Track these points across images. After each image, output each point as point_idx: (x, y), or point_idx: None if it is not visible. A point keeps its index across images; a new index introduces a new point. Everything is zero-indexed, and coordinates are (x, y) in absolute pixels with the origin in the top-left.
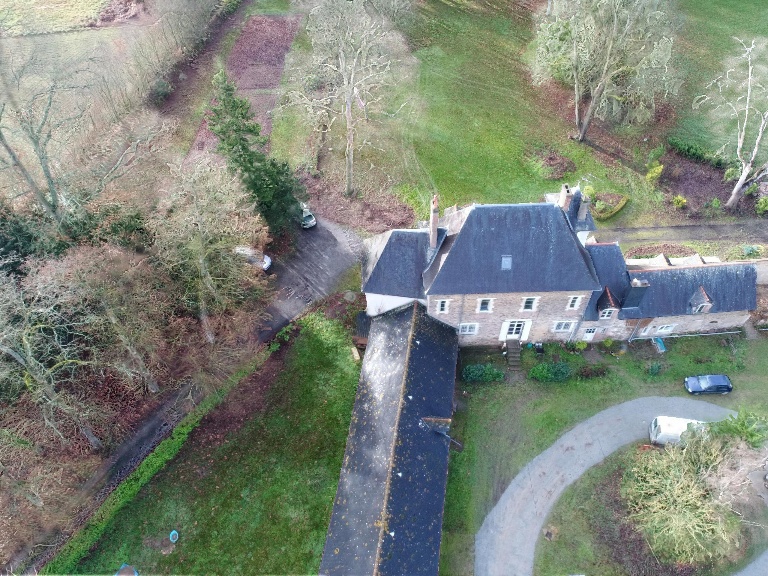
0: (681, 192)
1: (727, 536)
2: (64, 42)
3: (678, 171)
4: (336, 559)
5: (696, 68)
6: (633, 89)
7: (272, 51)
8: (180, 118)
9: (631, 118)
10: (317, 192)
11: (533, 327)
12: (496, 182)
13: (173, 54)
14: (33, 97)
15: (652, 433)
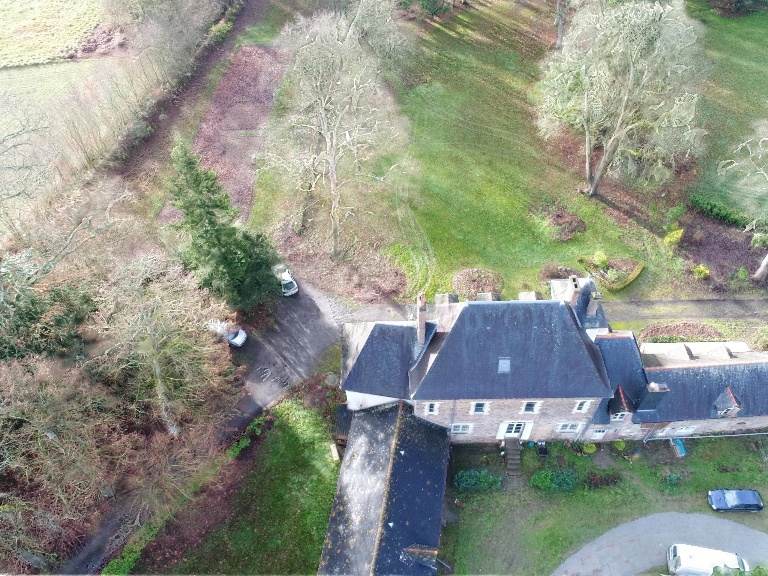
0: (703, 259)
1: None
2: (41, 75)
3: (700, 235)
4: None
5: (719, 111)
6: (650, 136)
7: (261, 87)
8: (158, 163)
9: (648, 175)
10: (301, 253)
11: (535, 427)
12: (497, 243)
13: (153, 93)
14: (3, 138)
15: (670, 561)
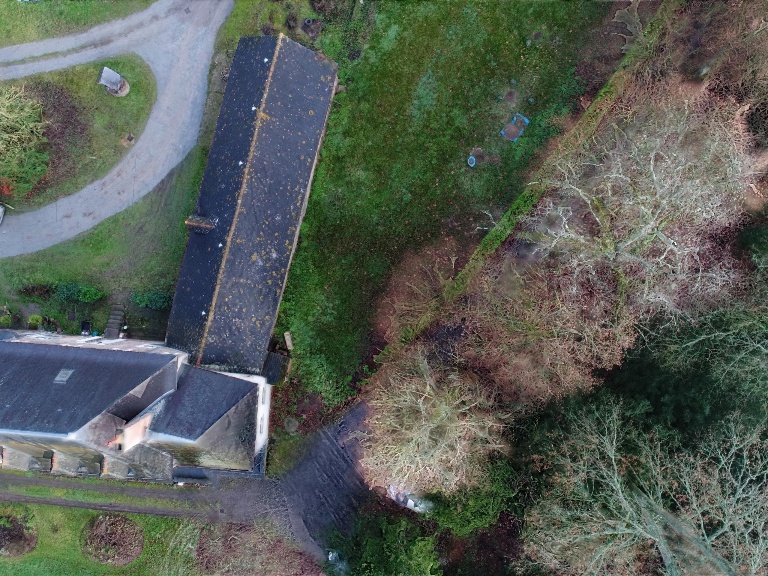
0: None
1: None
2: None
3: None
4: (312, 105)
5: None
6: None
7: None
8: None
9: None
10: None
11: None
12: None
13: None
14: None
15: None
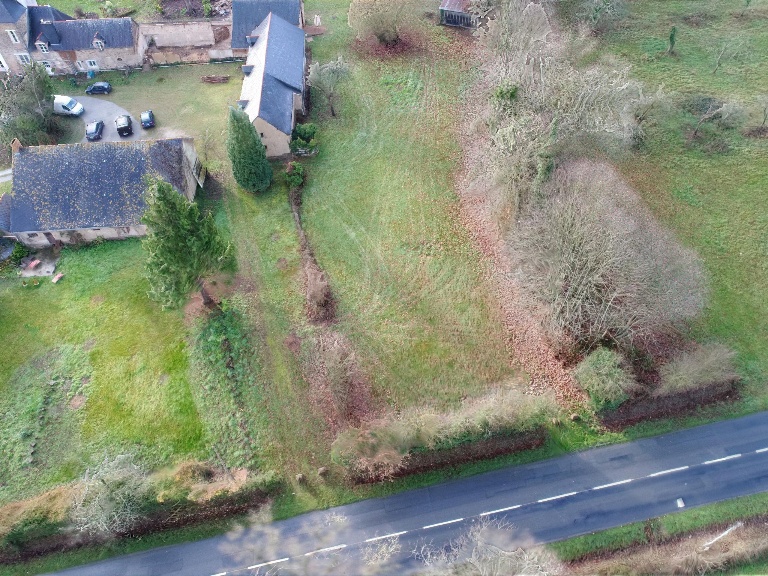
0: (169, 6)
1: (10, 121)
2: None
3: None
4: None
5: None
6: None
7: None
8: None
9: None
10: None
11: (6, 60)
12: (62, 4)
13: None
14: None
15: None
